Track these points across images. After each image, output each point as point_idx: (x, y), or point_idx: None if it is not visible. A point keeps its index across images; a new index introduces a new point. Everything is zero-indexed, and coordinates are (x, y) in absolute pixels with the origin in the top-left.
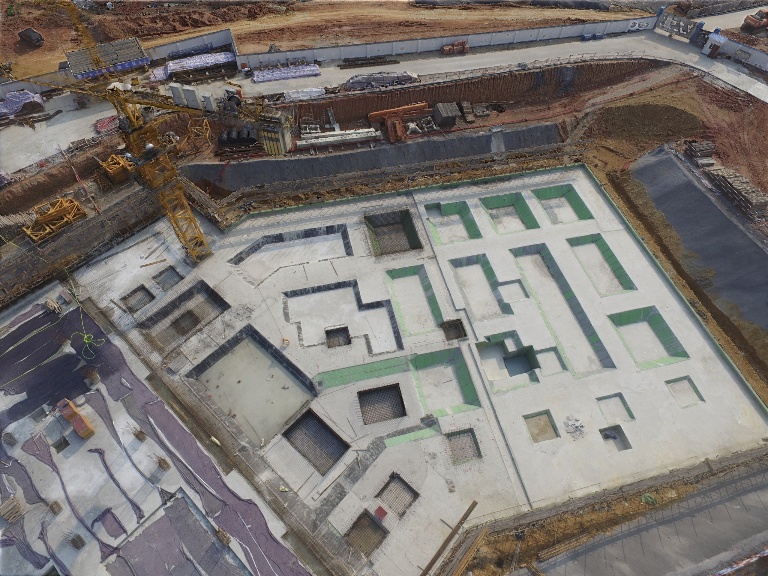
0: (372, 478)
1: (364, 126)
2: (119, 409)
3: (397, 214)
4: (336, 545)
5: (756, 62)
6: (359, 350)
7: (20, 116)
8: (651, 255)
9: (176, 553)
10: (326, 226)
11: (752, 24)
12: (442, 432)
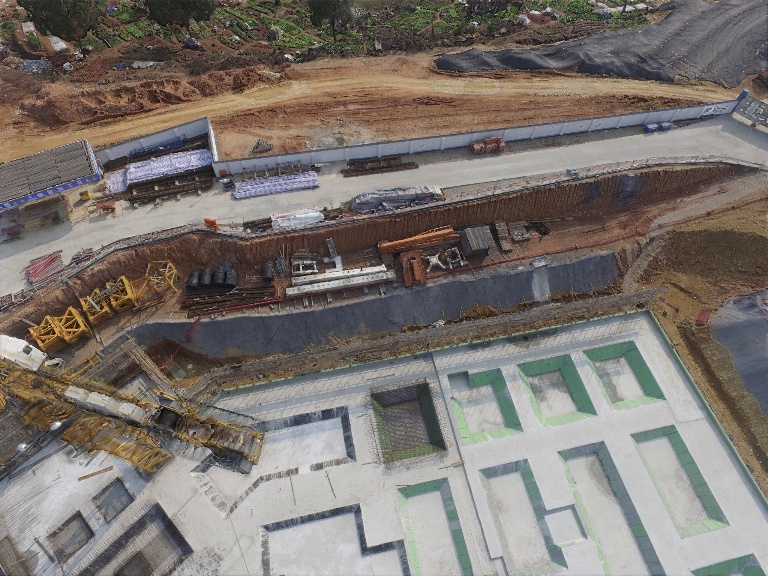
0: None
1: (372, 258)
2: None
3: (413, 389)
4: None
5: None
6: None
7: None
8: (744, 467)
9: None
10: (322, 410)
11: None
12: None
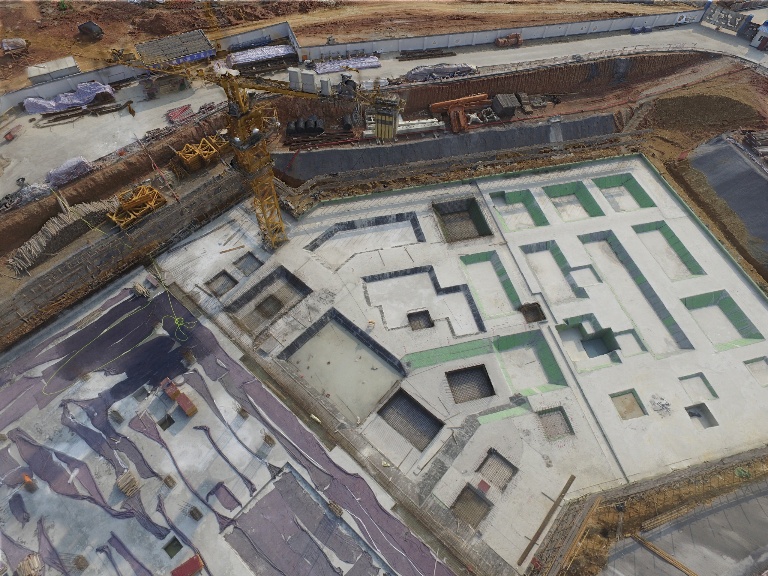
0: (471, 454)
1: (425, 117)
2: (218, 388)
3: (463, 202)
4: (444, 517)
5: None
6: (443, 332)
7: (92, 107)
8: (717, 241)
9: (291, 524)
10: (396, 214)
11: None
12: (533, 410)
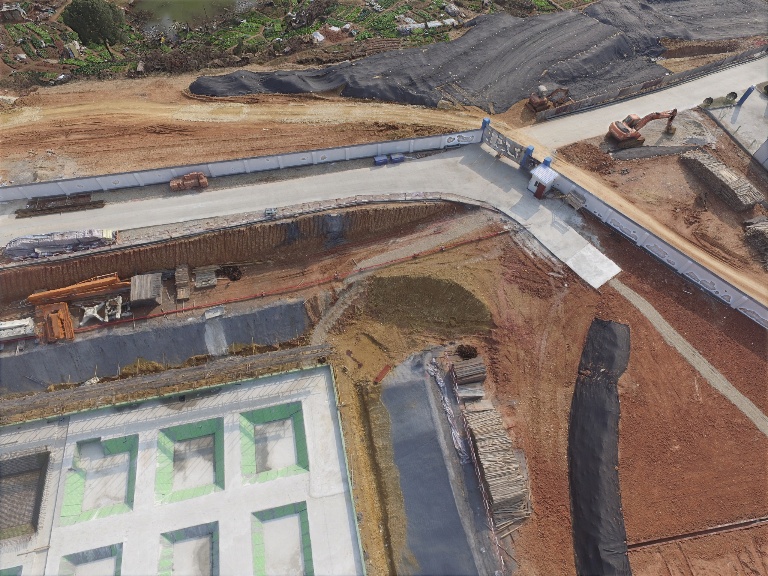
0: None
1: (27, 309)
2: None
3: (32, 458)
4: None
5: (594, 209)
6: None
7: None
8: None
9: None
10: None
11: (616, 135)
12: None
